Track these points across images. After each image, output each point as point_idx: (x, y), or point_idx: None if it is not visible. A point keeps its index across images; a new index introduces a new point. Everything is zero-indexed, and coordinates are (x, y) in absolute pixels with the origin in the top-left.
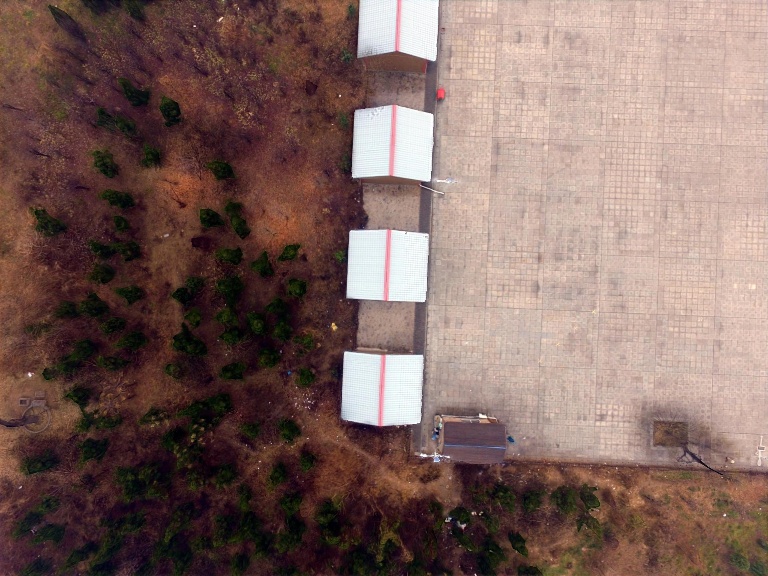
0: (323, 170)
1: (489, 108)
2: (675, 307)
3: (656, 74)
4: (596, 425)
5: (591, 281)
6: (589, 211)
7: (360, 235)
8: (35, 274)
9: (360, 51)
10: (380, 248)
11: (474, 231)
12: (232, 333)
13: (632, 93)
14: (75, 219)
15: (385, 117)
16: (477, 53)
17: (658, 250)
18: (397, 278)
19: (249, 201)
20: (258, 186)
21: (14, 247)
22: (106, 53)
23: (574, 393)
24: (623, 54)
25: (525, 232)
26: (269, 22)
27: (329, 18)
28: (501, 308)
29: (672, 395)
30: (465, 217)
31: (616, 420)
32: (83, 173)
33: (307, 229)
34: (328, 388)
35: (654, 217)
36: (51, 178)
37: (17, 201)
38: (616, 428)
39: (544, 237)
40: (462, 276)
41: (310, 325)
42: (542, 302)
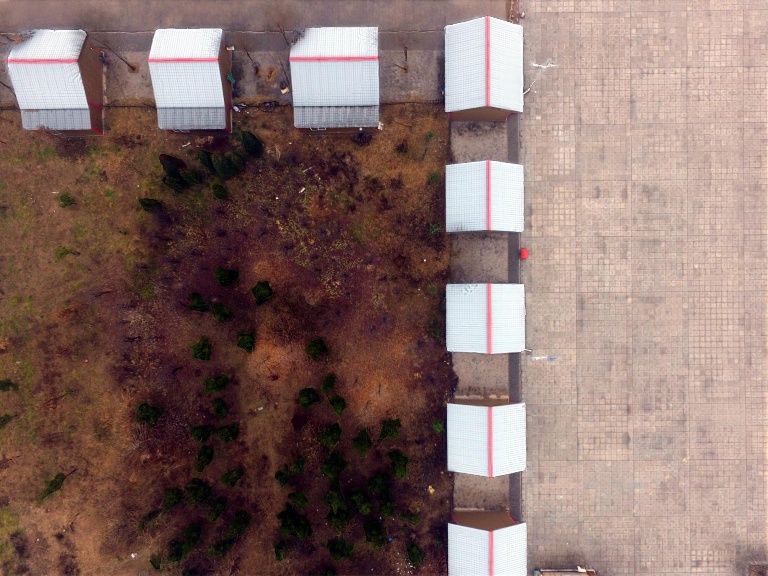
0: (412, 336)
1: (572, 264)
2: (763, 451)
3: (734, 223)
4: (692, 571)
5: (680, 430)
6: (675, 361)
7: (459, 409)
8: (136, 462)
9: (449, 226)
10: (481, 424)
11: (563, 386)
12: (340, 517)
13: (711, 243)
14: (169, 398)
15: (480, 294)
16: (557, 210)
17: (744, 396)
18: (499, 453)
19: (341, 370)
20: (349, 354)
21: (110, 429)
22: (191, 230)
23: (669, 541)
24: (701, 205)
25: (613, 385)
26: (351, 190)
27: (410, 184)
28: (593, 461)
29: (765, 538)
30: (553, 373)
31: (711, 565)
32: (174, 352)
33: (399, 395)
34: (429, 551)
35: (739, 364)
36: (143, 359)
37: (110, 383)
38: (712, 573)
39: (632, 389)
40: (553, 431)
41: (410, 494)
42: (633, 453)
